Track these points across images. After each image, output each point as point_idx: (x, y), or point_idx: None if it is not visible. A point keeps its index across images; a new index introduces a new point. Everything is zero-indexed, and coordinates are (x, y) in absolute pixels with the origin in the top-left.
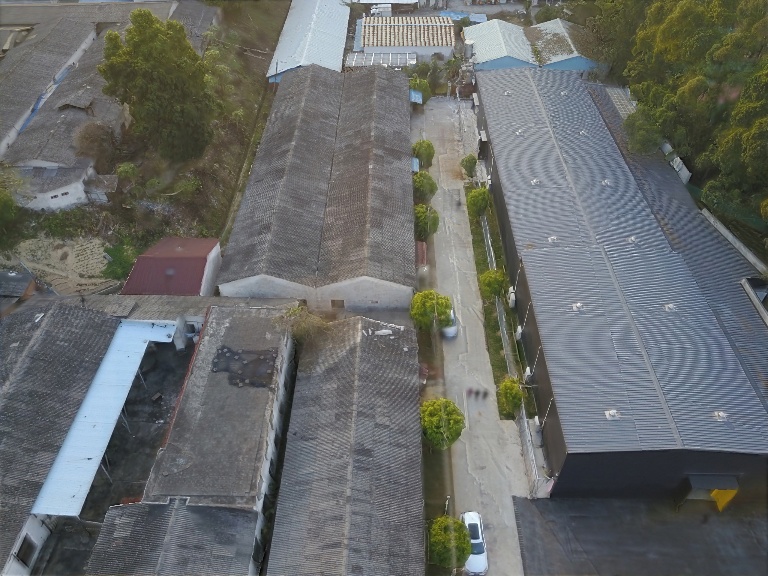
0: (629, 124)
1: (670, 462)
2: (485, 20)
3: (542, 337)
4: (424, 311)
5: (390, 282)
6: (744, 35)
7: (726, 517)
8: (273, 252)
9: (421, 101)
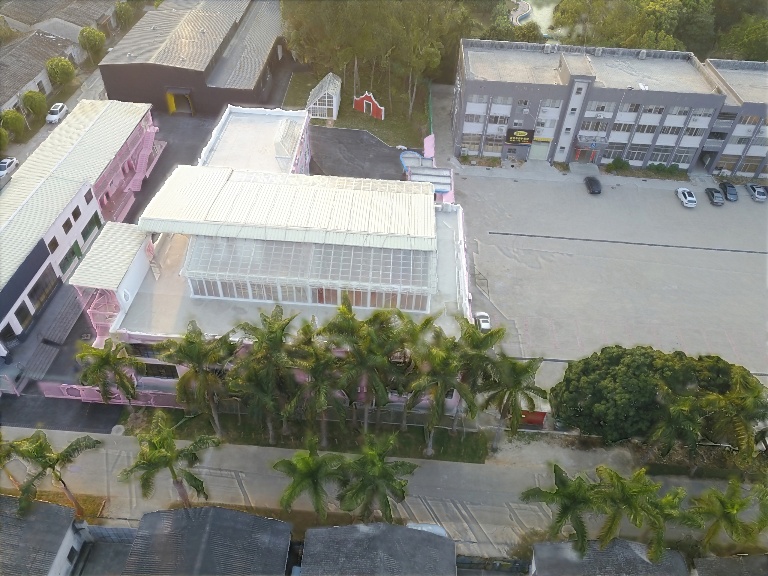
0: None
1: (153, 77)
2: None
3: (125, 36)
4: (82, 35)
5: (71, 23)
6: None
7: (194, 118)
8: (10, 7)
9: None
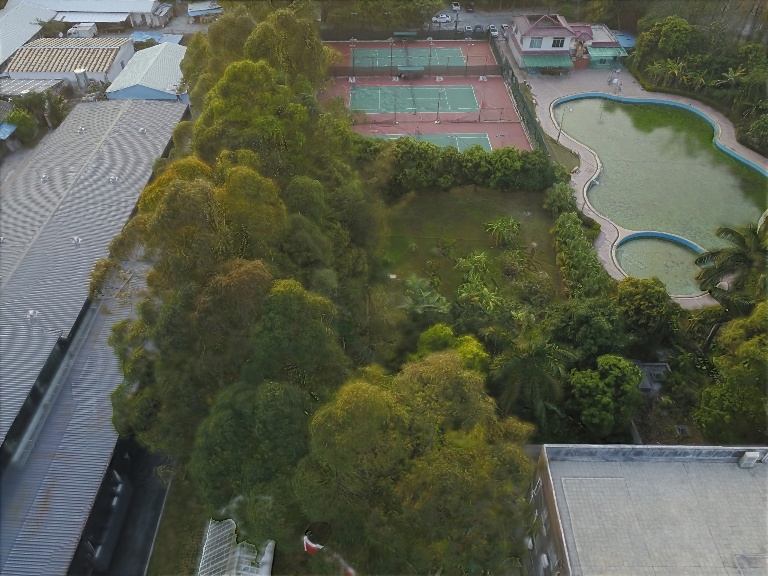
0: (154, 170)
1: None
2: (176, 42)
3: None
4: None
5: None
6: (211, 77)
7: None
8: None
9: (6, 136)
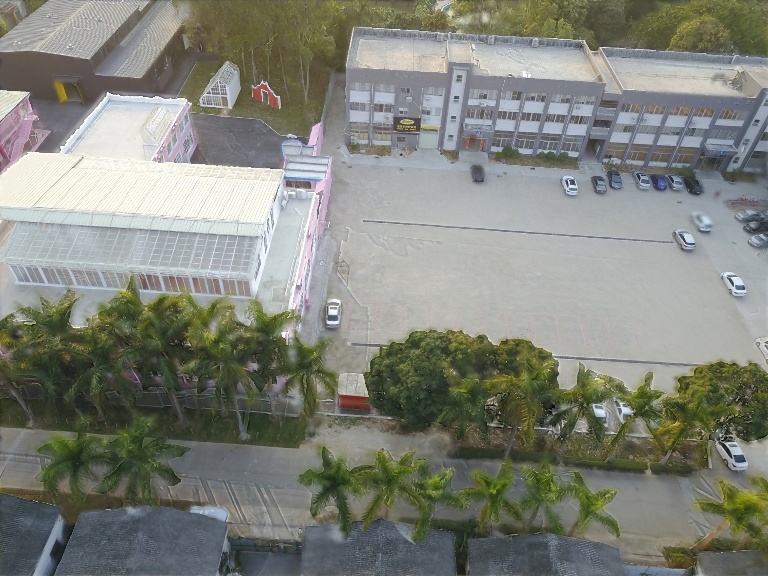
0: None
1: (39, 65)
2: None
3: (18, 24)
4: None
5: None
6: None
7: (85, 107)
8: None
9: None
